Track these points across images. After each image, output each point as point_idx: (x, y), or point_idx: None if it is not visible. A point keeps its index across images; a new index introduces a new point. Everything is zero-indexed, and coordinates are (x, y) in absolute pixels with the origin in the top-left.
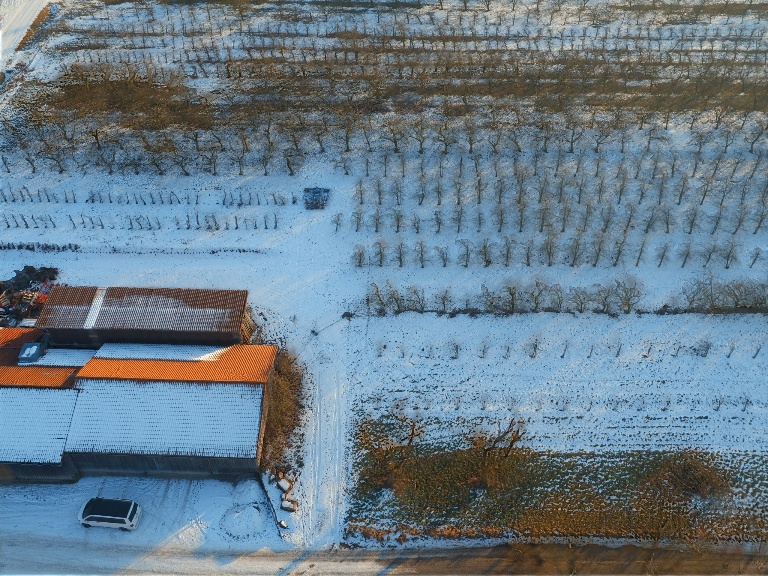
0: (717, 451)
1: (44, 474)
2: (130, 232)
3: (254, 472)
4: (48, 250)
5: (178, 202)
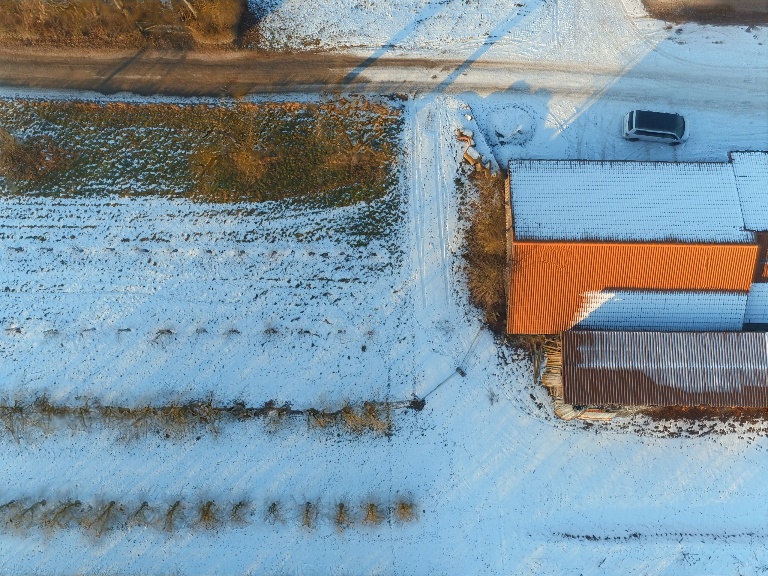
0: None
1: None
2: None
3: None
4: None
5: None
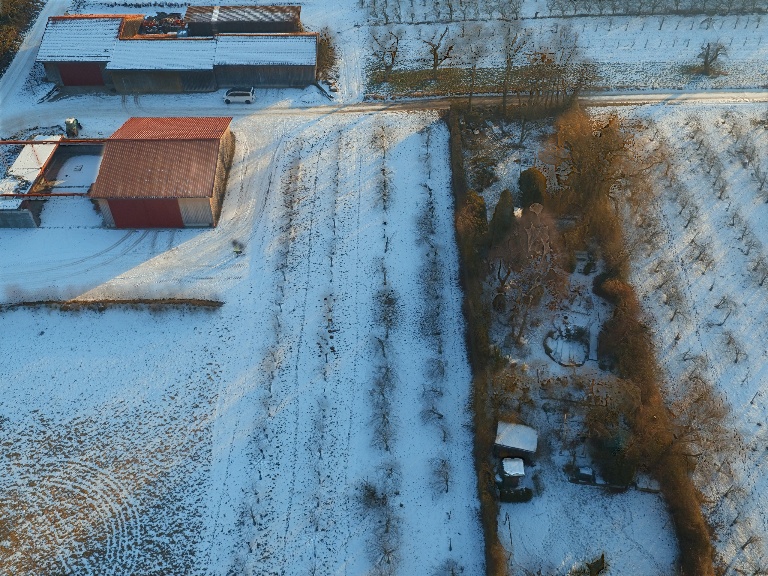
0: (557, 64)
1: (199, 87)
2: None
3: (313, 83)
4: (172, 6)
5: None
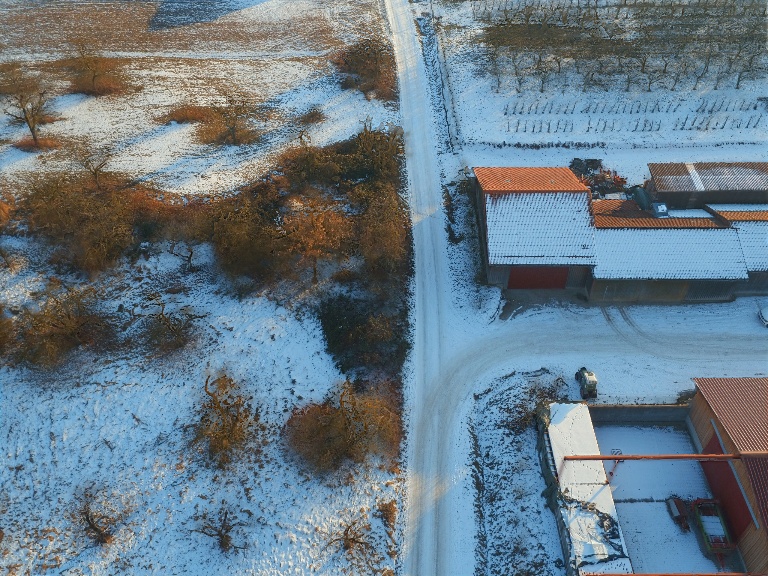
0: None
1: (708, 295)
2: (638, 133)
3: None
4: (581, 147)
5: (658, 111)
